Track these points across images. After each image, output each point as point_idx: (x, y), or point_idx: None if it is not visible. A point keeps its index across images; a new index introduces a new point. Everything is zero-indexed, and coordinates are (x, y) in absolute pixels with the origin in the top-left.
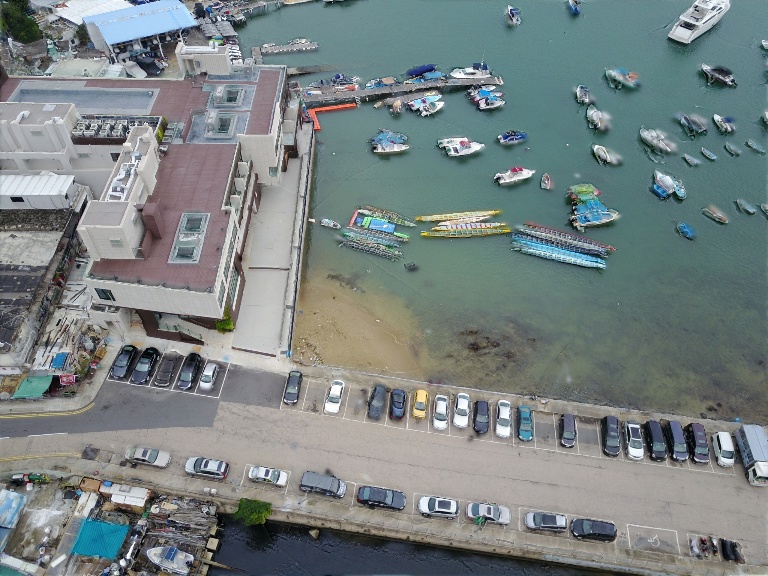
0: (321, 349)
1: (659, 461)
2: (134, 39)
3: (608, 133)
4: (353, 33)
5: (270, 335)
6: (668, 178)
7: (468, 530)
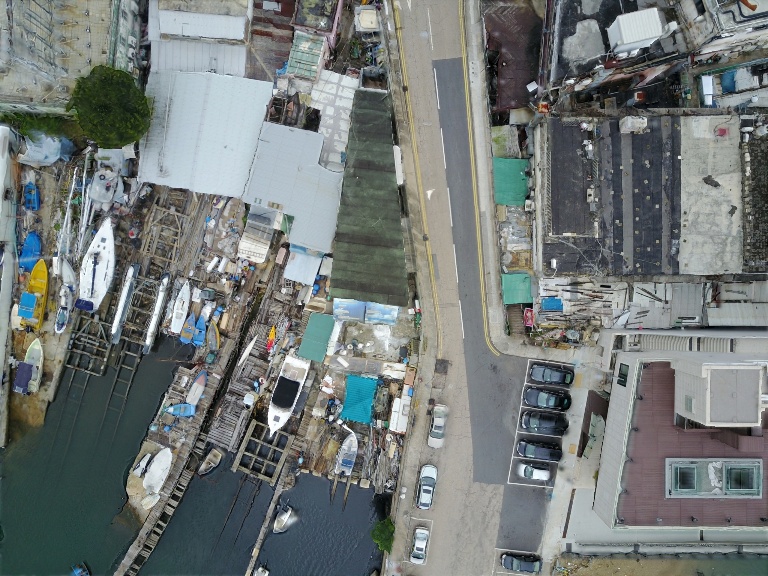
0: (584, 573)
1: None
2: None
3: None
4: None
5: (594, 529)
6: None
7: None
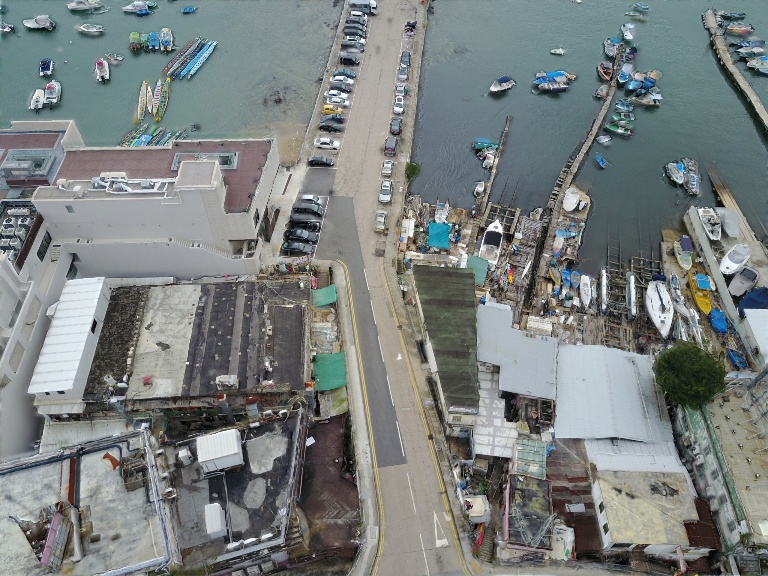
0: None
1: (366, 36)
2: None
3: (63, 23)
4: None
5: None
6: (137, 2)
7: (410, 99)
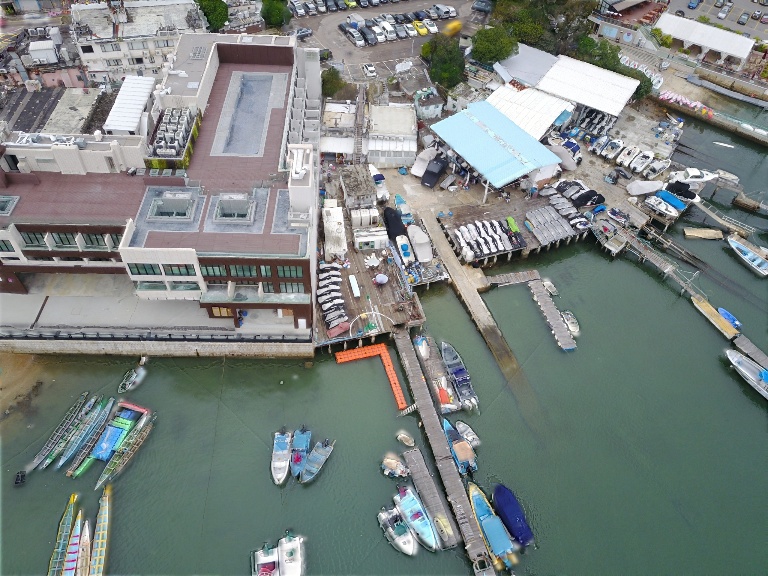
0: None
1: None
2: (448, 143)
3: None
4: (642, 404)
5: None
6: None
7: None
